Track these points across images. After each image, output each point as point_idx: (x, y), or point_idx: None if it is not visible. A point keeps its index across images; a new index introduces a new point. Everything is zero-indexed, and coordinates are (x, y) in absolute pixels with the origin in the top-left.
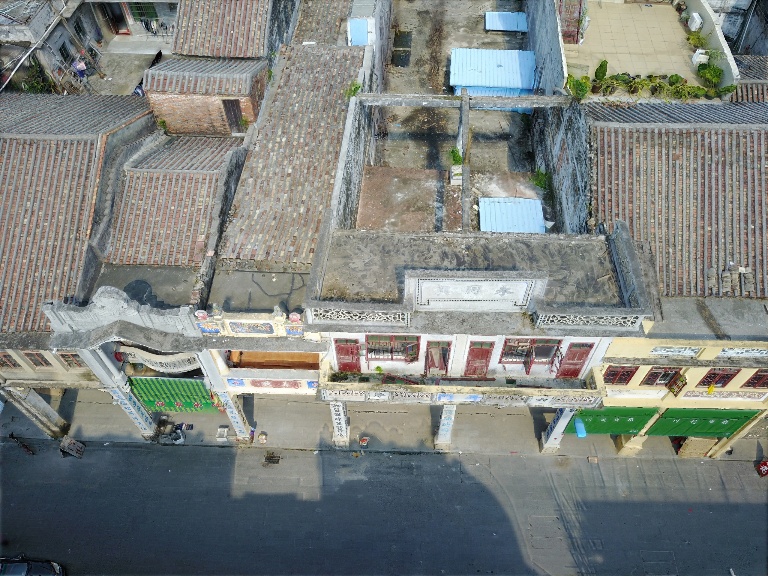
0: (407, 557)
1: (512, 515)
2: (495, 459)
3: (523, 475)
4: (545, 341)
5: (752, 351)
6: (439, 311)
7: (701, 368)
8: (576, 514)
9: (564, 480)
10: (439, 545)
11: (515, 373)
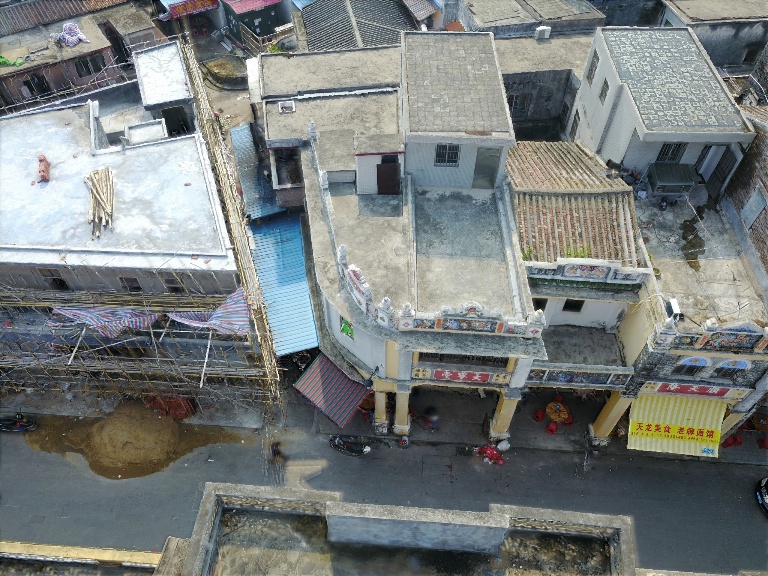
0: None
1: None
2: None
3: None
4: None
5: None
6: None
7: None
8: None
9: None
10: None
11: None
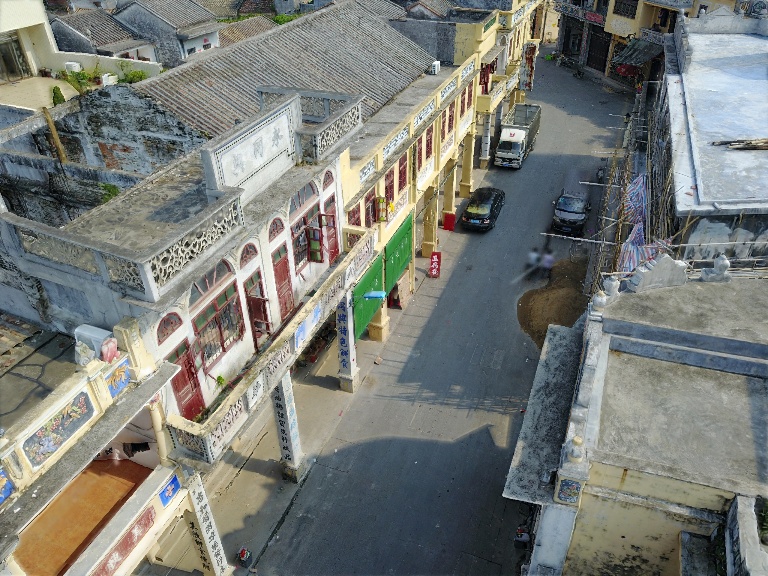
0: (409, 560)
1: (403, 440)
2: (338, 433)
3: (367, 416)
4: (311, 213)
5: (391, 146)
6: (245, 205)
7: (383, 181)
8: (422, 391)
9: (387, 388)
10: (408, 519)
11: (308, 283)
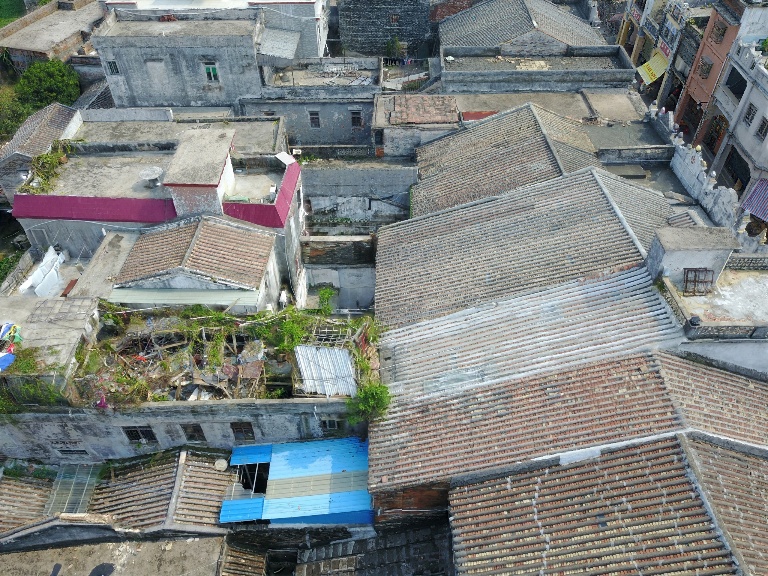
0: None
1: None
2: None
3: None
4: None
5: None
6: None
7: None
8: None
9: None
10: None
11: None
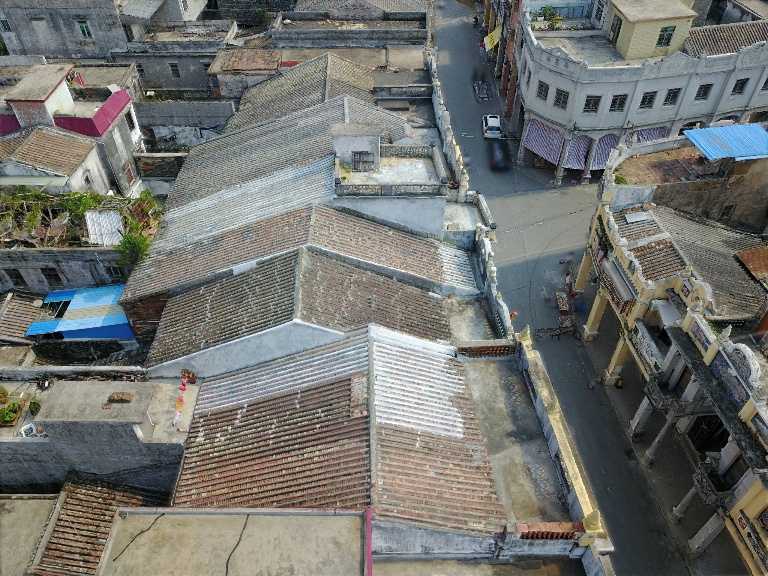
0: None
1: None
2: None
3: None
4: None
5: None
6: None
7: None
8: None
9: None
10: None
11: None
